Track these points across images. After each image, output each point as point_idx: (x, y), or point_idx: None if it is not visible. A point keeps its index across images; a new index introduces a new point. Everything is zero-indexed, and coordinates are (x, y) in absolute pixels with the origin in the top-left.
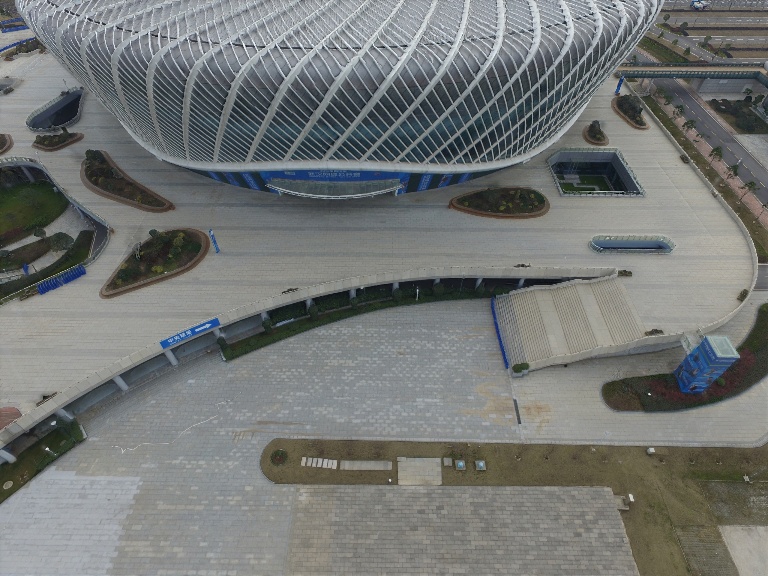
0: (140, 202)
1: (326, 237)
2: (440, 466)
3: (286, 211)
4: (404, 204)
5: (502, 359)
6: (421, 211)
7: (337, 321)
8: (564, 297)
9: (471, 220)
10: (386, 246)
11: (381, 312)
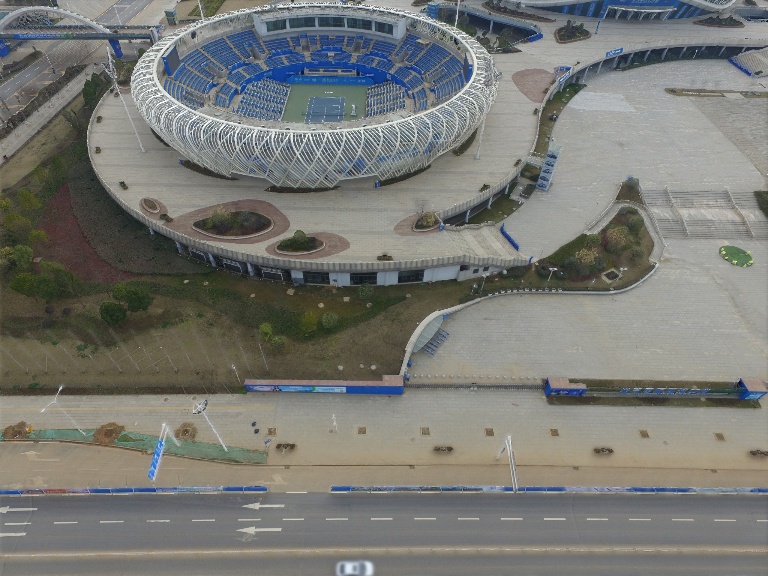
0: (538, 18)
1: (643, 31)
2: (741, 94)
3: (613, 23)
4: (670, 23)
5: (746, 74)
6: (681, 25)
7: (661, 63)
8: (767, 53)
9: (709, 28)
10: (675, 34)
11: (679, 61)
